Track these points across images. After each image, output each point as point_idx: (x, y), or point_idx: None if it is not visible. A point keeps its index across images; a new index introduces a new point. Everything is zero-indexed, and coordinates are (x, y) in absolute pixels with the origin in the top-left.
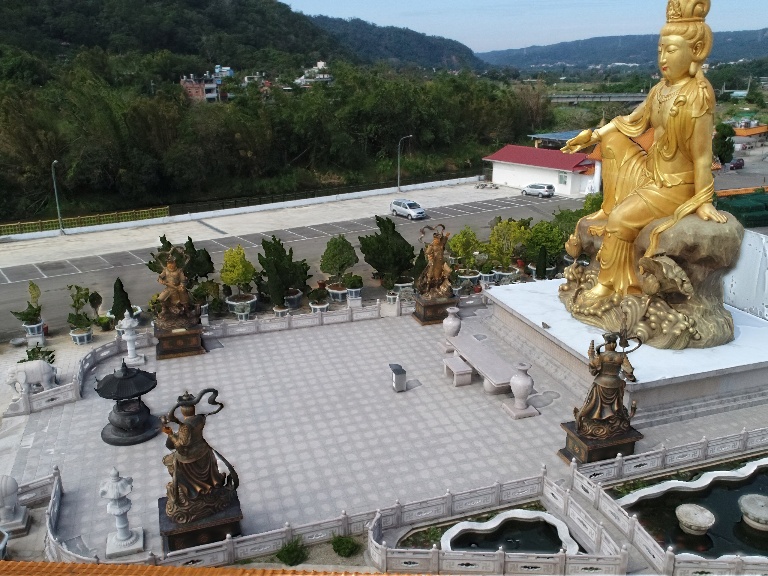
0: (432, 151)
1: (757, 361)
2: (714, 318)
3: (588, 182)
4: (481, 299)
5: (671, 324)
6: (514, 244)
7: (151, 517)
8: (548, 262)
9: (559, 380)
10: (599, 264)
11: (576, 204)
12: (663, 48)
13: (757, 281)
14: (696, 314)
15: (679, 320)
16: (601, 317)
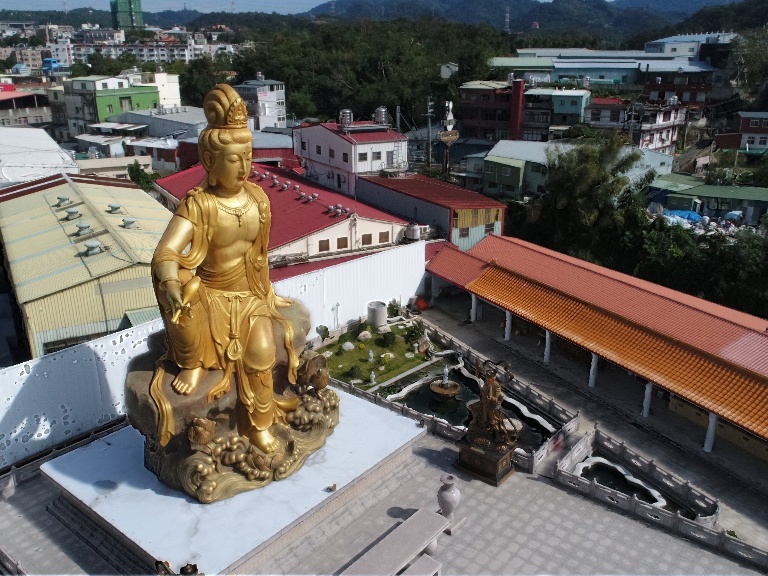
0: None
1: None
2: None
3: None
4: None
5: None
6: None
7: None
8: None
9: None
10: None
11: None
12: None
13: None
14: None
15: None
16: None
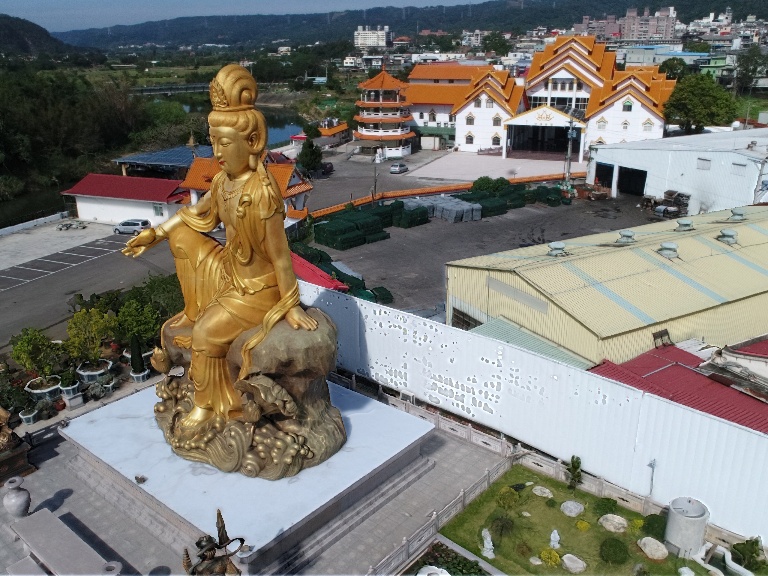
0: (5, 171)
1: (371, 469)
2: (323, 427)
3: None
4: None
5: (281, 452)
6: (99, 336)
7: None
8: (146, 345)
9: (167, 545)
10: None
11: None
12: (215, 140)
13: (359, 344)
14: (305, 429)
15: (288, 445)
16: (205, 450)
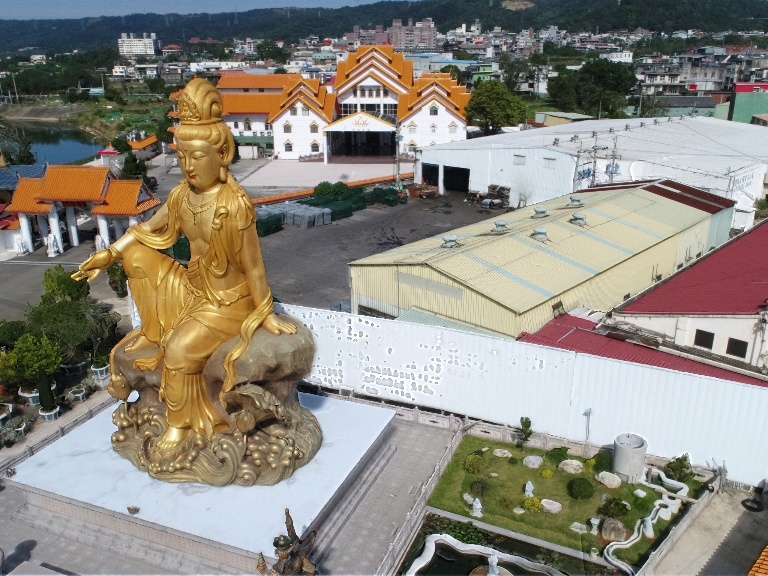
0: None
1: (359, 458)
2: (306, 427)
3: (16, 238)
4: None
5: (277, 456)
6: None
7: None
8: None
9: (174, 570)
10: (155, 398)
11: (13, 270)
12: (187, 154)
13: None
14: (291, 431)
15: (283, 448)
16: (191, 469)
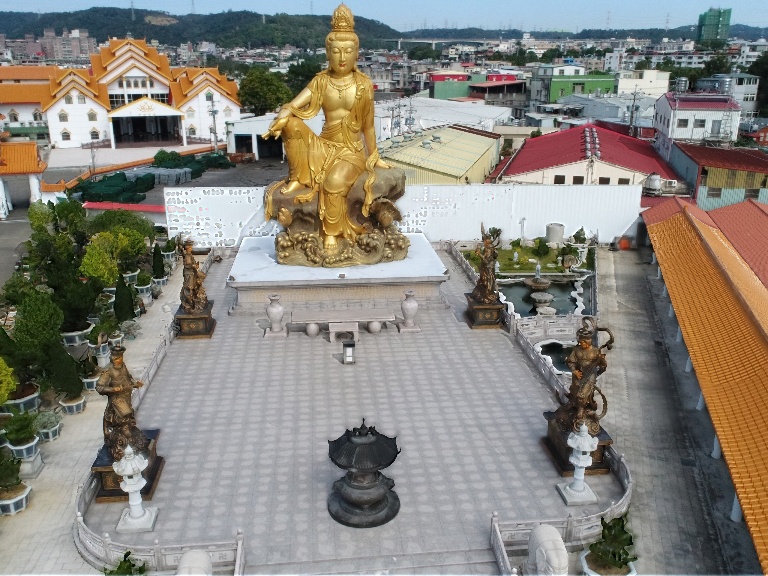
0: None
1: None
2: None
3: None
4: None
5: None
6: None
7: (537, 484)
8: (132, 265)
9: None
10: (301, 226)
11: None
12: (343, 50)
13: None
14: None
15: None
16: (353, 258)
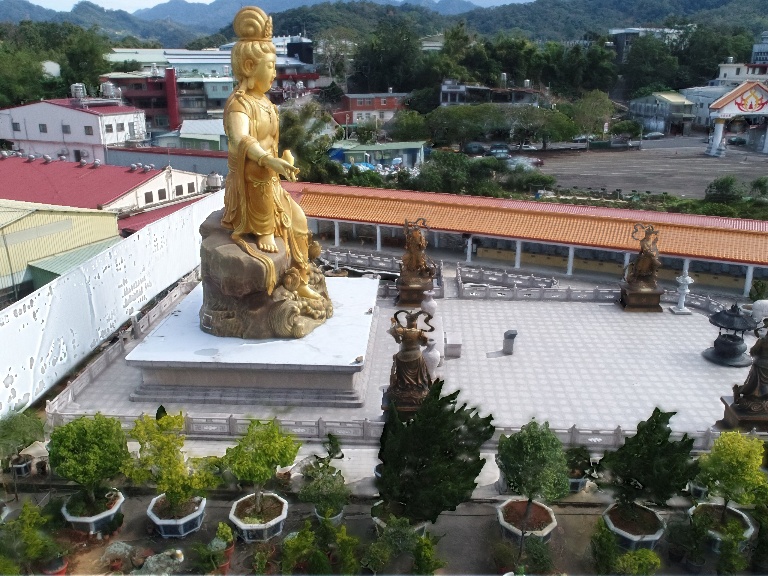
0: None
1: None
2: None
3: None
4: (327, 428)
5: None
6: None
7: None
8: None
9: None
10: None
11: None
12: None
13: None
14: None
15: None
16: None
